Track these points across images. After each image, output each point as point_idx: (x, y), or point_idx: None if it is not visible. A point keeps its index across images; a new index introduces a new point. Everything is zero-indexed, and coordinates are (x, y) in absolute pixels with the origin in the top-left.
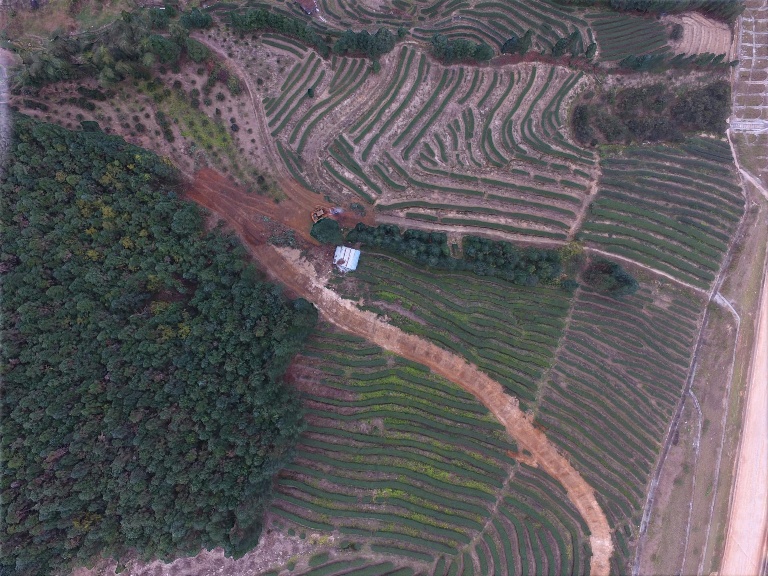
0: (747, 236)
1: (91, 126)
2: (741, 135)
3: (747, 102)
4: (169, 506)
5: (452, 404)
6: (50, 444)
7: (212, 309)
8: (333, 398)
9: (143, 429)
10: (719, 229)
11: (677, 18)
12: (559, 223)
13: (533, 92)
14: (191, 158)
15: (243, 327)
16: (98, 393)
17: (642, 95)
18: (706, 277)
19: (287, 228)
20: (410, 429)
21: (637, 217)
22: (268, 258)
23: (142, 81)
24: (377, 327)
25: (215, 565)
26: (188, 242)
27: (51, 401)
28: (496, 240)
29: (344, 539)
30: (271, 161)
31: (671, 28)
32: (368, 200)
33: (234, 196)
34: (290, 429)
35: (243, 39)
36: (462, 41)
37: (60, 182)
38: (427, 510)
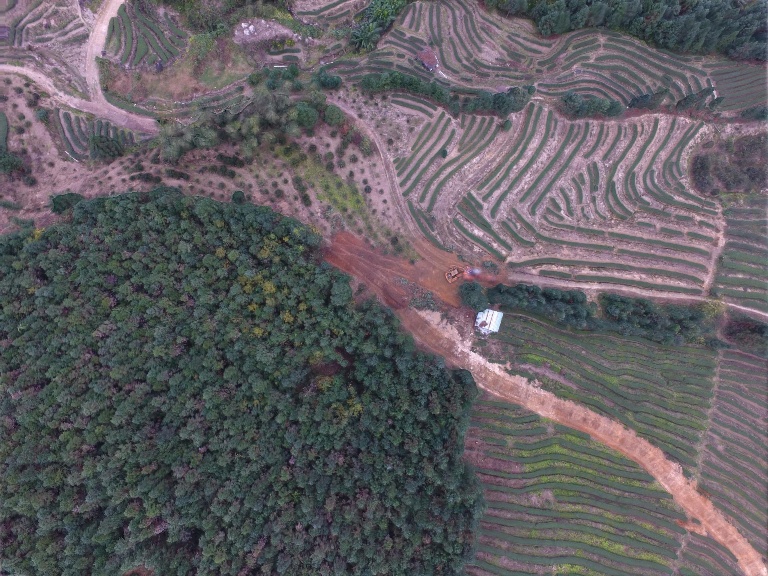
0: None
1: (239, 197)
2: None
3: None
4: None
5: (618, 473)
6: (251, 536)
7: (383, 386)
8: (500, 470)
9: (341, 518)
10: None
11: None
12: (693, 278)
13: (655, 144)
14: (327, 221)
15: (417, 404)
16: (287, 480)
17: (760, 143)
18: None
19: (425, 290)
20: (581, 501)
21: None
22: (410, 322)
23: (278, 146)
24: (530, 393)
25: None
26: (347, 314)
27: (246, 491)
28: (632, 297)
29: None
30: (403, 221)
31: None
32: (499, 257)
33: (371, 259)
34: (481, 512)
35: (373, 100)
36: (598, 100)
37: (219, 258)
38: None
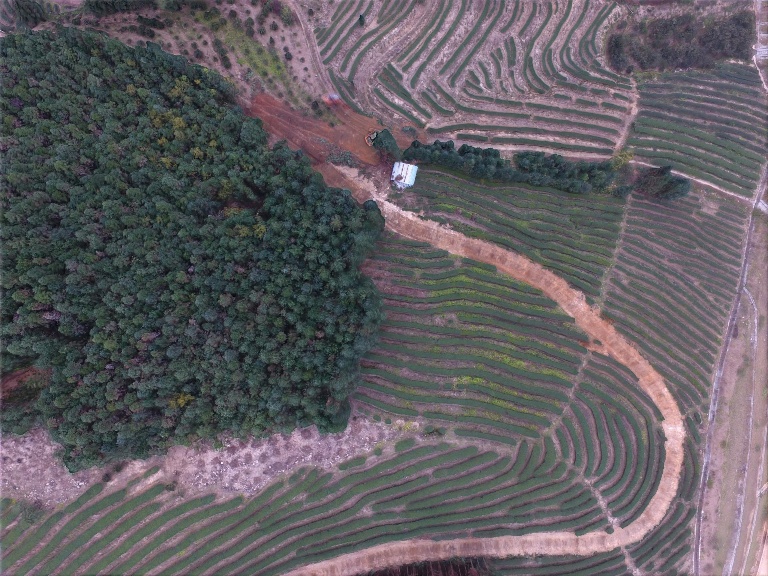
0: None
1: (155, 47)
2: (767, 61)
3: None
4: (262, 385)
5: (522, 298)
6: (143, 327)
7: (287, 208)
8: (406, 295)
9: (234, 311)
10: (756, 143)
11: None
12: (605, 140)
13: (570, 22)
14: (247, 84)
15: (319, 223)
16: (184, 282)
17: (672, 24)
18: (749, 186)
19: (343, 149)
20: (484, 321)
21: (678, 134)
22: (328, 176)
23: (198, 11)
24: (441, 234)
25: (304, 452)
26: (257, 151)
27: (140, 288)
28: None
29: (428, 424)
30: (324, 88)
31: None
32: (418, 124)
33: (291, 120)
34: (375, 312)
35: None
36: None
37: (130, 95)
38: (507, 395)
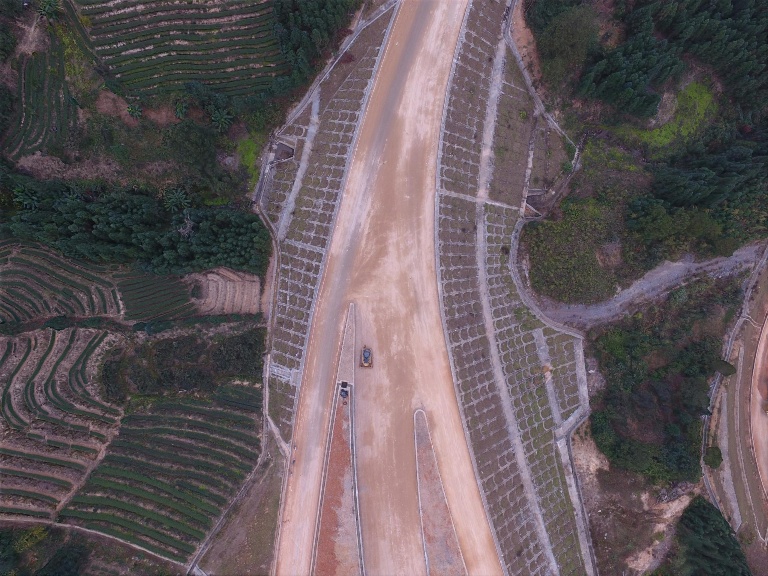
0: (246, 497)
1: None
2: (274, 380)
3: (280, 348)
4: None
5: None
6: None
7: None
8: None
9: None
10: (218, 491)
11: (202, 276)
12: (48, 498)
13: (54, 355)
14: None
15: None
16: None
17: (173, 347)
18: (185, 550)
19: None
20: None
21: (134, 485)
22: None
23: None
24: None
25: None
26: None
27: None
28: None
29: None
30: None
31: None
32: None
33: None
34: None
35: None
36: None
37: None
38: None
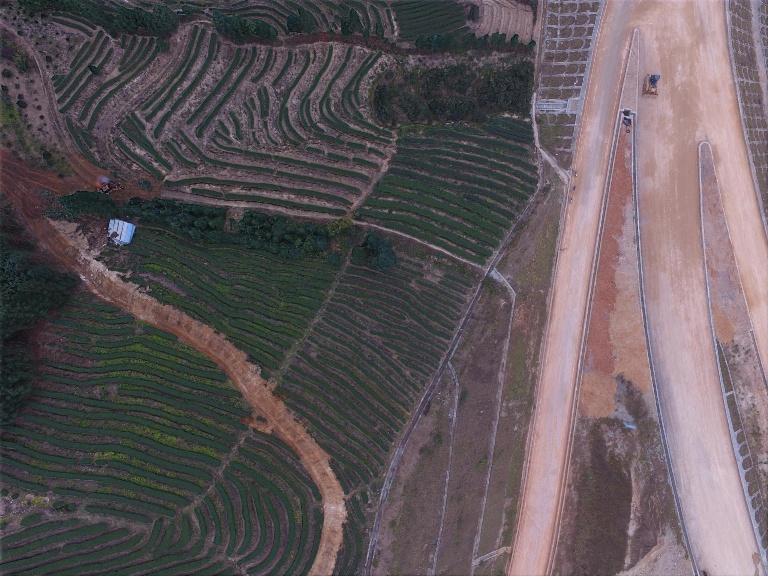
0: (533, 213)
1: None
2: (544, 115)
3: (550, 83)
4: None
5: (190, 371)
6: None
7: None
8: (71, 364)
9: None
10: (505, 206)
11: None
12: (342, 199)
13: (330, 71)
14: None
15: None
16: None
17: (444, 75)
18: (483, 253)
19: None
20: (142, 395)
21: (423, 194)
22: (43, 231)
23: None
24: (135, 297)
25: None
26: None
27: None
28: None
29: (59, 500)
30: (60, 137)
31: (470, 9)
32: (158, 176)
33: (16, 171)
34: None
35: (33, 17)
36: (237, 19)
37: None
38: (146, 473)
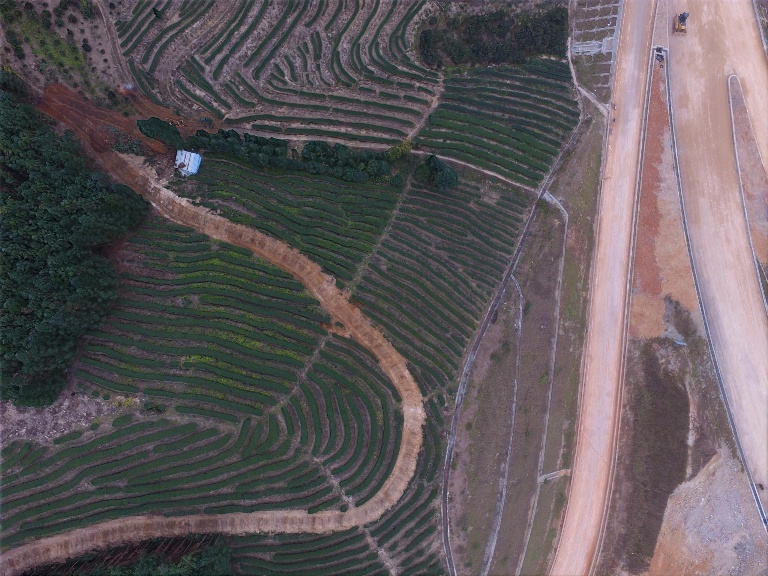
0: (578, 142)
1: None
2: (580, 57)
3: (584, 27)
4: None
5: (269, 281)
6: None
7: (30, 191)
8: (153, 277)
9: None
10: (551, 136)
11: None
12: (397, 131)
13: (379, 17)
14: (42, 74)
15: (58, 205)
16: None
17: (484, 21)
18: (535, 177)
19: (134, 138)
20: (224, 303)
21: (473, 126)
22: (112, 163)
23: None
24: (207, 219)
25: (18, 426)
26: (18, 137)
27: None
28: None
29: (149, 401)
30: (123, 79)
31: None
32: (218, 115)
33: (83, 109)
34: (89, 290)
35: None
36: None
37: None
38: (233, 374)
